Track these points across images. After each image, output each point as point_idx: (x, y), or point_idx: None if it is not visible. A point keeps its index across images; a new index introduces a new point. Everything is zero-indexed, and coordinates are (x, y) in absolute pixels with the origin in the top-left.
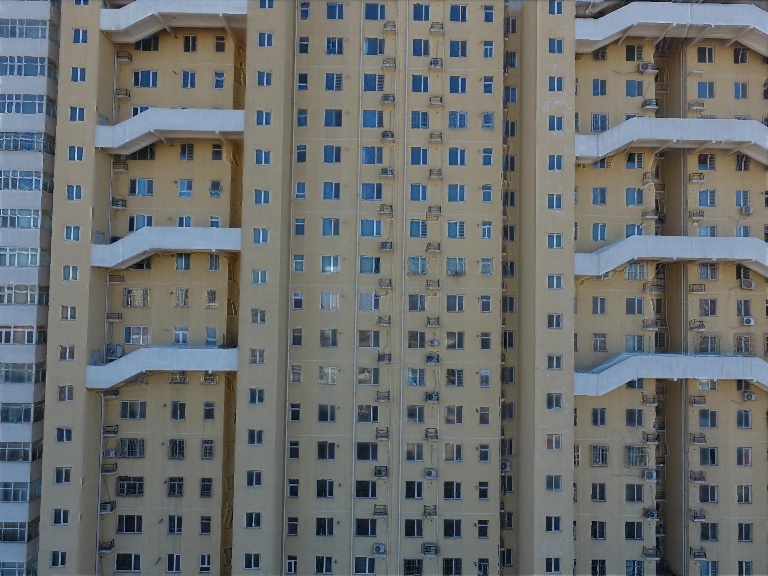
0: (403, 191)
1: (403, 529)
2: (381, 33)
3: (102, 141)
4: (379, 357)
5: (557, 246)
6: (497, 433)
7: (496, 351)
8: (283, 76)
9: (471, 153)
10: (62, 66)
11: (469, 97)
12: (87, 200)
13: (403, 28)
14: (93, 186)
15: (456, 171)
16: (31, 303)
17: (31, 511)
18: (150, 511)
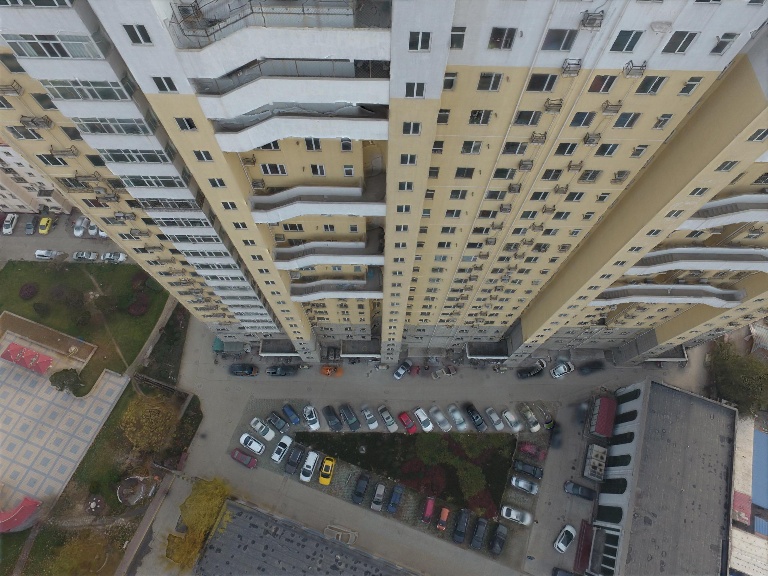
0: (516, 216)
1: (467, 315)
2: (540, 108)
3: (260, 220)
4: (470, 279)
5: (620, 264)
6: (533, 296)
7: (549, 275)
8: (425, 187)
9: (589, 197)
10: (198, 179)
11: (612, 161)
12: (262, 247)
13: (570, 103)
14: (263, 241)
15: (568, 206)
16: (235, 268)
17: (271, 317)
18: (331, 310)
